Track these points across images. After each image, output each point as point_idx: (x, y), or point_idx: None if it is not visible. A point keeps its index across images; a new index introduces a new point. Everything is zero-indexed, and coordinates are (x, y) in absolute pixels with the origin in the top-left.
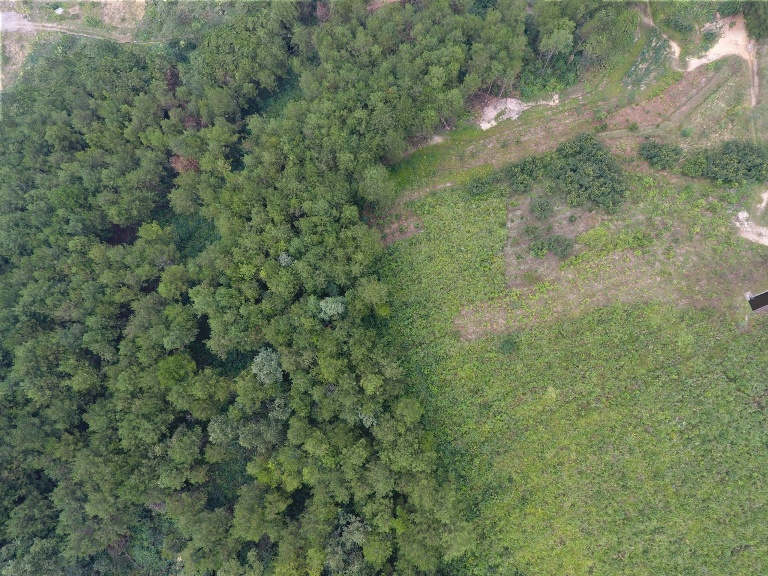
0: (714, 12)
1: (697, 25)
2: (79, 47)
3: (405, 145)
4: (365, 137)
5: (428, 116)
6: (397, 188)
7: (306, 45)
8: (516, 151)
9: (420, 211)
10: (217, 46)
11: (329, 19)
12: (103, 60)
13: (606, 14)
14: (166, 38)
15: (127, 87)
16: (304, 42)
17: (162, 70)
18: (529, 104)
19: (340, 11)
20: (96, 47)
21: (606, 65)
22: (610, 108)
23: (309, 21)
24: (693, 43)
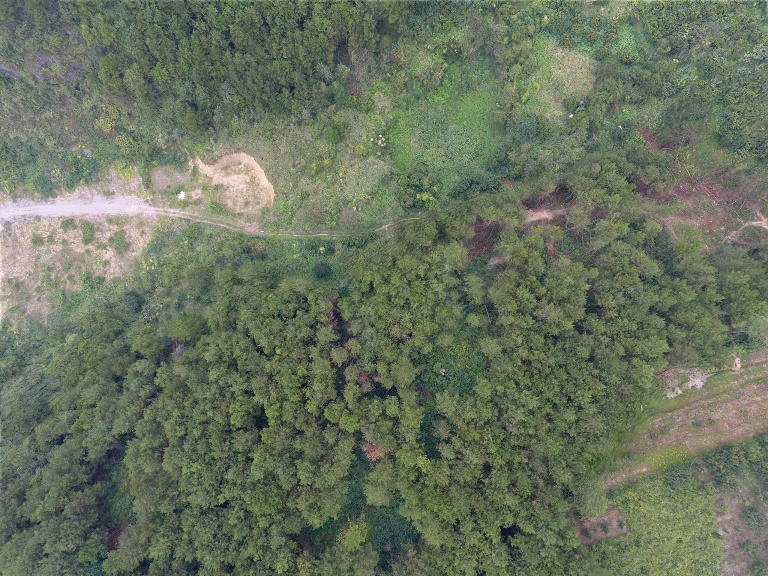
0: None
1: None
2: (206, 239)
3: (613, 445)
4: (574, 439)
5: (632, 409)
6: None
7: (482, 299)
8: (710, 432)
9: (624, 508)
10: (388, 295)
11: (507, 274)
12: (262, 296)
13: None
14: (296, 231)
15: (296, 338)
16: (480, 296)
17: (325, 311)
18: (713, 370)
19: (516, 263)
20: (227, 243)
21: None
22: None
23: None
24: None
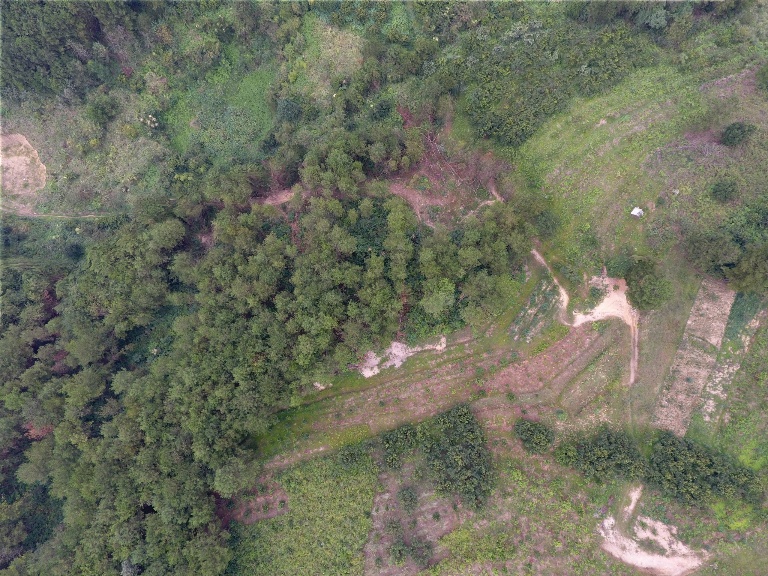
0: (601, 266)
1: (586, 275)
2: None
3: (269, 422)
4: (226, 416)
5: (297, 387)
6: (263, 462)
7: (186, 277)
8: (394, 412)
9: (286, 487)
10: (94, 273)
11: (210, 251)
12: None
13: (488, 273)
14: (67, 213)
15: None
16: (184, 274)
17: (38, 290)
18: (414, 350)
19: (223, 241)
20: None
21: (493, 313)
22: (493, 365)
23: (202, 228)
24: (580, 297)
